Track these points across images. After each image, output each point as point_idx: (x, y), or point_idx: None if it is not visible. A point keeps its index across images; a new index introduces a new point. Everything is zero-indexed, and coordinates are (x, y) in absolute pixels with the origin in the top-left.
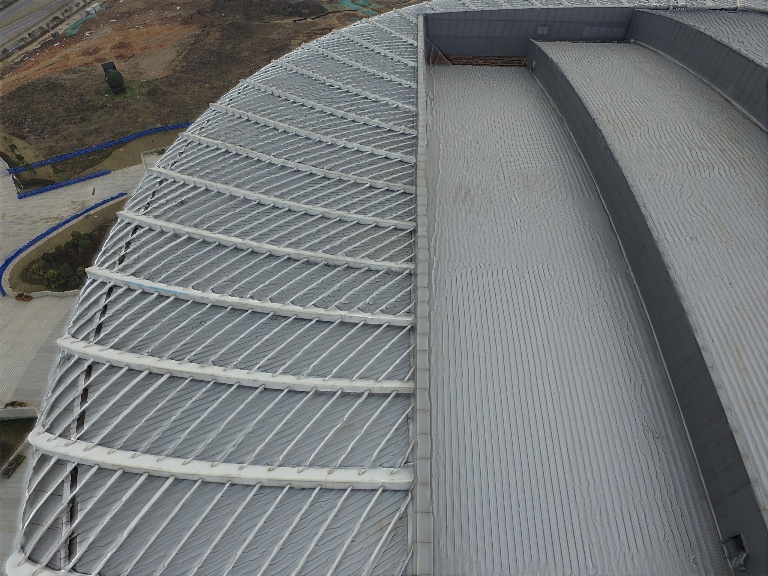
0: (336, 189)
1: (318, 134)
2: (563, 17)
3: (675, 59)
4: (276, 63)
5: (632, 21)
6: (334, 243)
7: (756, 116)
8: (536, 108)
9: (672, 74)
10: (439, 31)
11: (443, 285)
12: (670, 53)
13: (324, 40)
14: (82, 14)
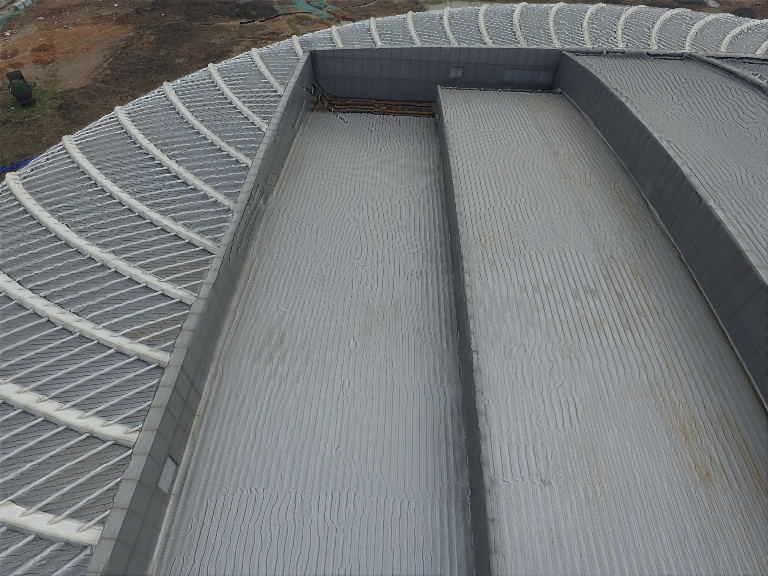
0: (67, 355)
1: (91, 247)
2: (479, 58)
3: (596, 127)
4: (115, 113)
5: (559, 66)
6: (9, 475)
7: (674, 237)
8: (416, 192)
9: (587, 152)
10: (333, 70)
11: (185, 530)
12: (593, 117)
13: (187, 81)
14: (11, 9)
